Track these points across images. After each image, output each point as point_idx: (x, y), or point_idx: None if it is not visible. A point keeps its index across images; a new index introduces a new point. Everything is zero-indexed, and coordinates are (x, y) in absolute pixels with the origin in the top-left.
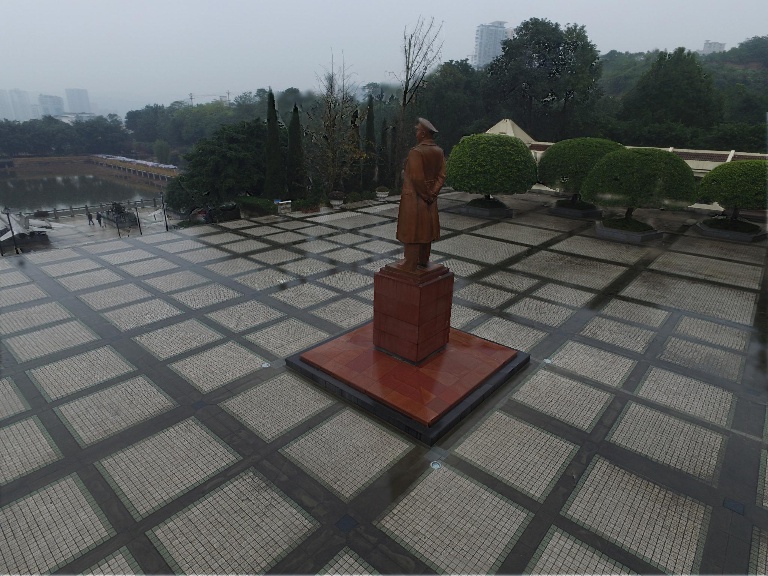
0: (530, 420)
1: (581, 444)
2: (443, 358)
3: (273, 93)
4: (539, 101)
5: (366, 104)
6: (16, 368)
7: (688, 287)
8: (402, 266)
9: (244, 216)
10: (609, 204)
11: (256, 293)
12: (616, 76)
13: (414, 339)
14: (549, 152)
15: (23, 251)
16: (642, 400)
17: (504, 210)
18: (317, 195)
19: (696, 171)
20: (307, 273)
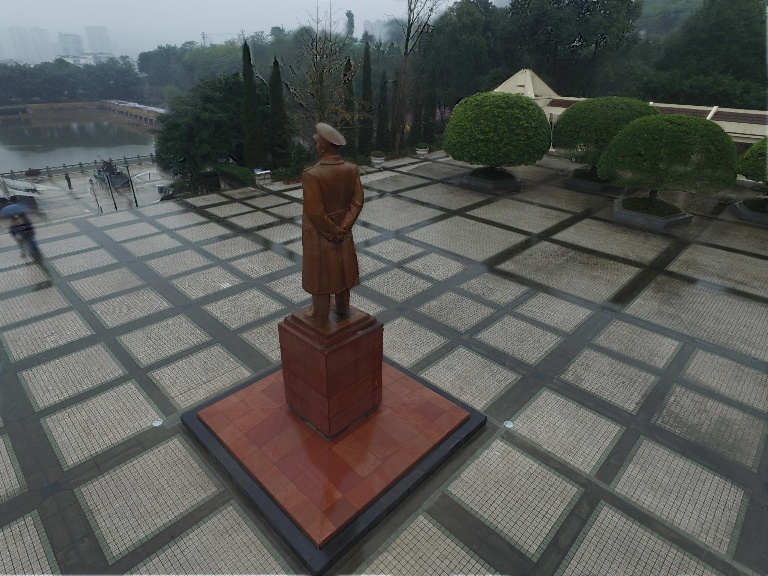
0: (461, 534)
1: None
2: (369, 427)
3: (248, 44)
4: (564, 47)
5: (362, 54)
6: None
7: (711, 301)
8: (310, 318)
9: (224, 185)
10: (629, 184)
11: (189, 304)
12: (658, 16)
13: (325, 411)
14: (567, 114)
15: (7, 216)
16: (619, 500)
17: (511, 182)
18: (300, 164)
19: (742, 136)
20: (258, 273)
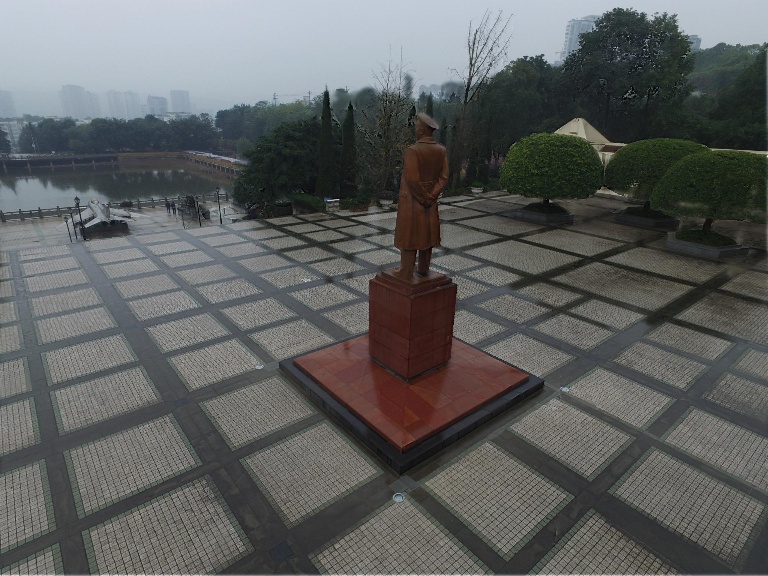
0: (523, 457)
1: (576, 494)
2: (440, 376)
3: (328, 91)
4: (617, 98)
5: (425, 102)
6: (35, 349)
7: (766, 314)
8: (398, 274)
9: (296, 213)
10: (681, 213)
11: (276, 291)
12: (711, 70)
13: (405, 353)
14: (619, 154)
15: None
16: (669, 448)
17: (563, 216)
18: (366, 194)
19: None
20: (333, 273)
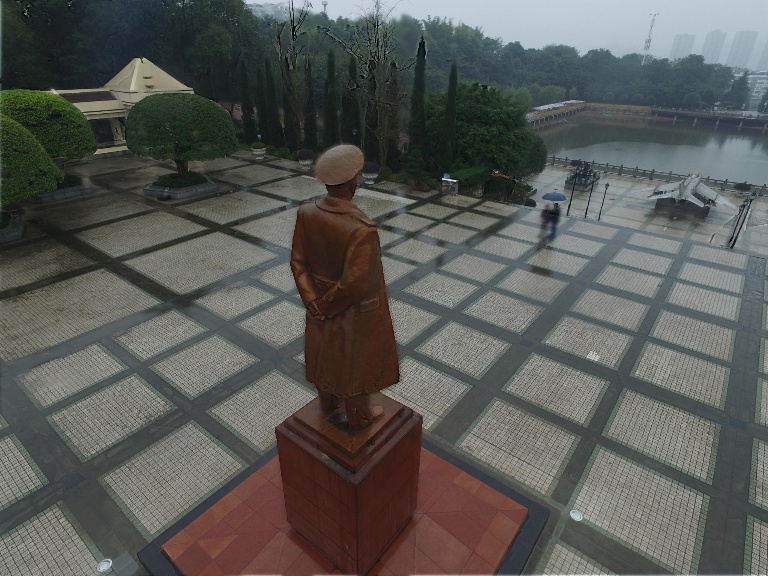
0: None
1: None
2: (316, 574)
3: None
4: None
5: None
6: None
7: None
8: None
9: None
10: None
11: (532, 342)
12: None
13: None
14: None
15: (669, 215)
16: None
17: None
18: None
19: None
20: (648, 375)
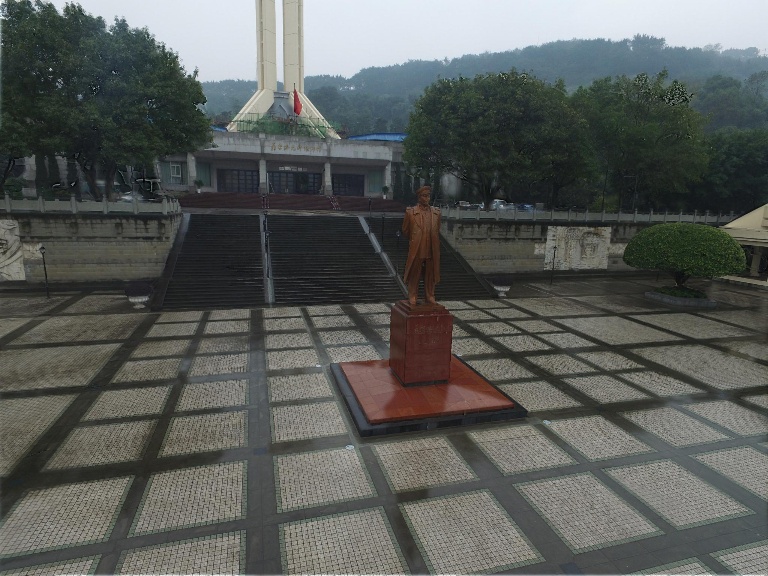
0: None
1: None
2: None
3: None
4: None
5: None
6: None
7: (3, 370)
8: None
9: None
10: None
11: None
12: None
13: None
14: None
15: None
16: None
17: None
18: None
19: None
20: None
